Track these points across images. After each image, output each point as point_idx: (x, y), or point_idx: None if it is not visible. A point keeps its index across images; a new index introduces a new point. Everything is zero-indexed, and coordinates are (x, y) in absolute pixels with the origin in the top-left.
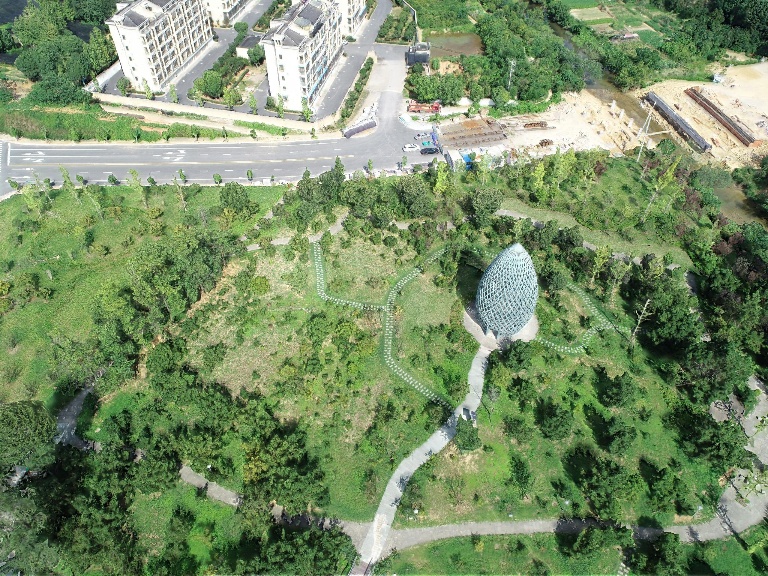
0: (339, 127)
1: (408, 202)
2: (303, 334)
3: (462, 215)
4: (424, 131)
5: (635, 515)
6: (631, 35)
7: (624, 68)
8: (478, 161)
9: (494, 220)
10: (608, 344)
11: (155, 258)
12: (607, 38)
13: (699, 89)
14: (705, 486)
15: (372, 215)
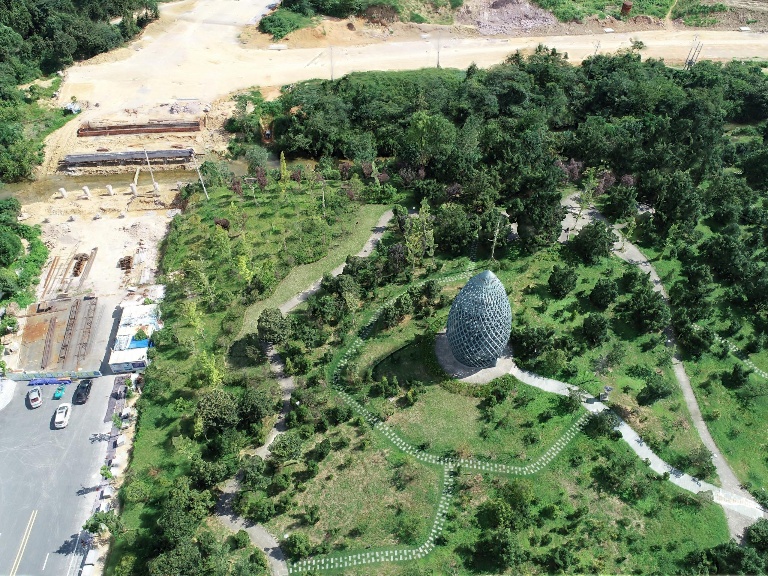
0: None
1: None
2: None
3: (289, 359)
4: (18, 394)
5: None
6: None
7: (3, 161)
8: (151, 333)
9: None
10: None
11: None
12: None
13: None
14: (618, 264)
15: None
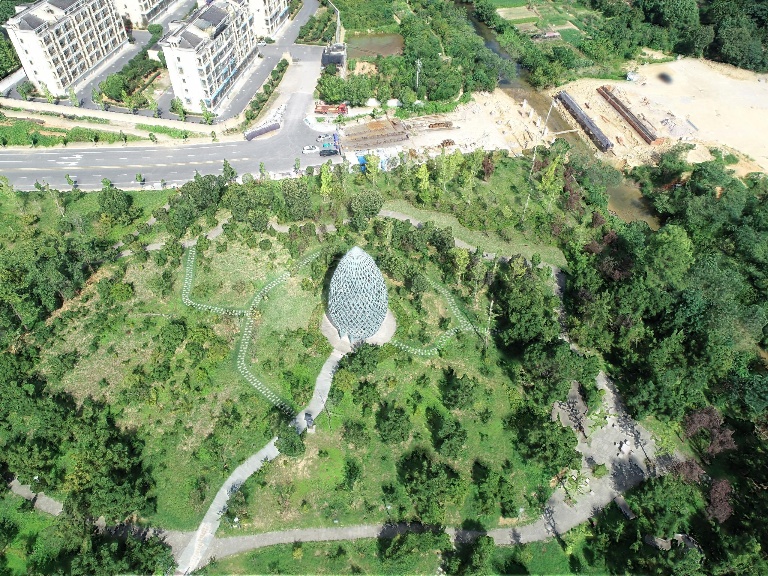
0: (242, 129)
1: (290, 205)
2: (159, 340)
3: (341, 217)
4: (327, 133)
5: (460, 518)
6: (552, 34)
7: (539, 67)
8: None
9: (377, 222)
10: (464, 346)
11: (14, 266)
12: (529, 37)
13: (611, 87)
14: (535, 487)
15: (247, 219)
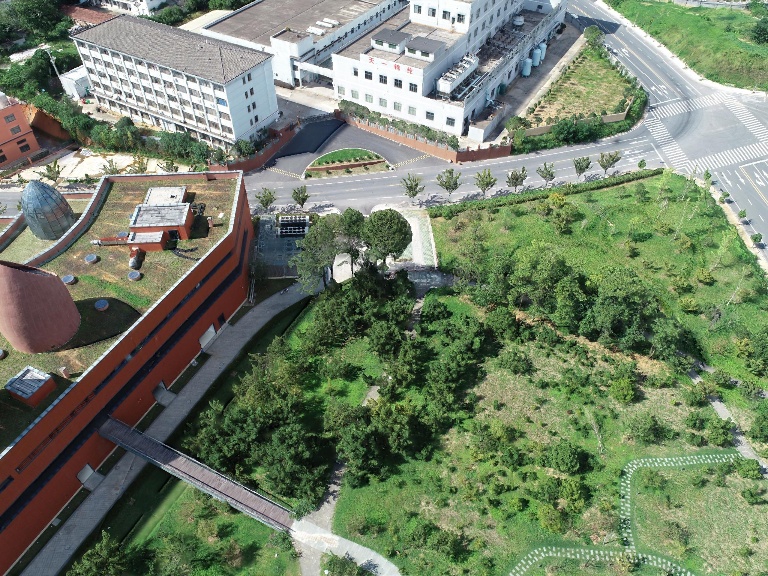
0: None
1: None
2: None
3: None
4: None
5: None
6: None
7: None
8: None
9: None
10: None
11: None
12: None
13: None
14: None
15: None
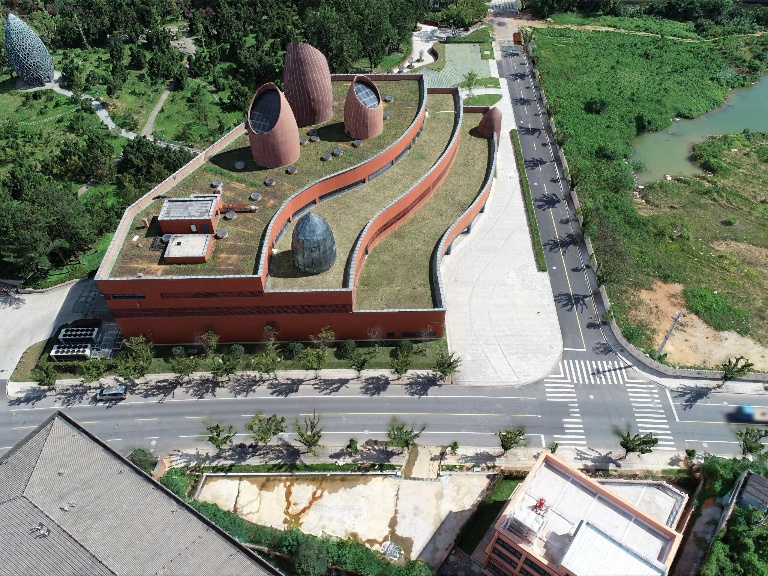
0: None
1: None
2: None
3: None
4: None
5: None
6: None
7: None
8: None
9: None
10: (84, 56)
11: None
12: None
13: None
14: None
15: None
